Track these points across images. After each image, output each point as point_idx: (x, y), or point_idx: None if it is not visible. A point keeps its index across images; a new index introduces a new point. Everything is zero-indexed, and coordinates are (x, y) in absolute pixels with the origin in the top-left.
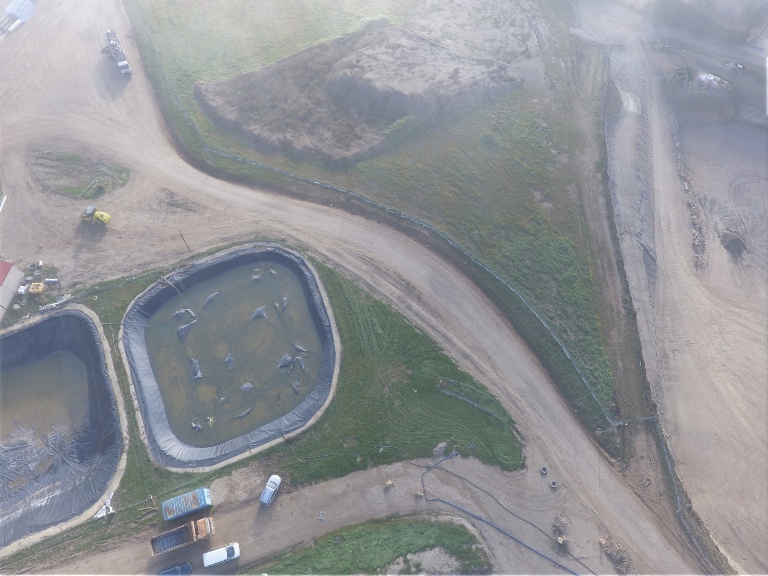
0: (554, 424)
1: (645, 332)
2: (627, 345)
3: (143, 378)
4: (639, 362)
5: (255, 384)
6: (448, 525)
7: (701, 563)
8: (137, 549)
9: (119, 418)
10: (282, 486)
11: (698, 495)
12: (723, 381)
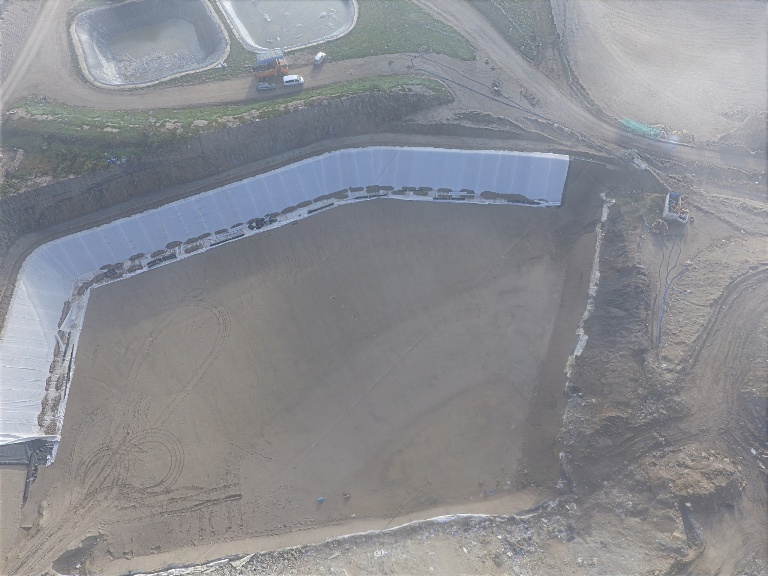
0: (494, 44)
1: (557, 10)
2: (543, 8)
3: (234, 18)
4: (550, 16)
5: (305, 24)
6: (428, 79)
7: (582, 103)
8: (242, 80)
9: (222, 32)
10: (326, 59)
11: (587, 91)
12: (609, 43)
